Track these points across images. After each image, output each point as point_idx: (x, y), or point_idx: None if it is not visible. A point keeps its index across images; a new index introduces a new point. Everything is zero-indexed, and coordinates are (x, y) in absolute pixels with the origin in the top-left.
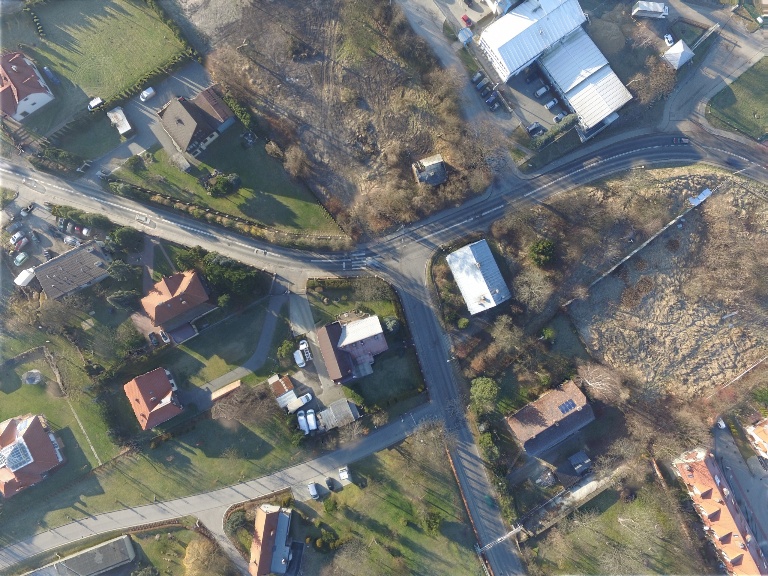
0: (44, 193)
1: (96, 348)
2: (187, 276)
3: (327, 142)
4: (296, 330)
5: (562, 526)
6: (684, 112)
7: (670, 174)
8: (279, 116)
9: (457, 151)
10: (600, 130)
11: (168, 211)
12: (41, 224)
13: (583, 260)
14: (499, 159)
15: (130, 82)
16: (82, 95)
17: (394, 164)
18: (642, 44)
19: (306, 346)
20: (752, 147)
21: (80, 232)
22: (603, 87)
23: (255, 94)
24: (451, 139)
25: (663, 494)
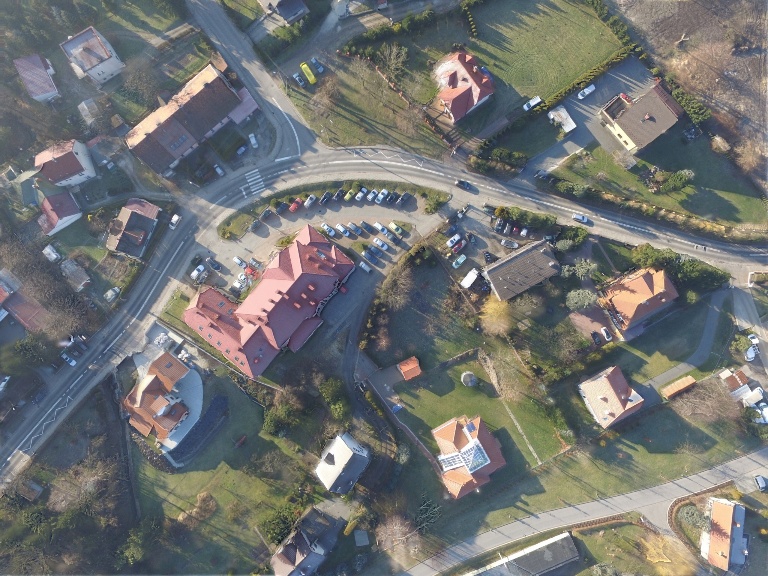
0: (478, 194)
1: (533, 348)
2: (656, 274)
3: (766, 136)
4: (741, 324)
5: None
6: None
7: None
8: (719, 111)
9: None
10: None
11: (605, 209)
12: (475, 226)
13: None
14: None
15: (565, 80)
16: (515, 94)
17: None
18: None
19: (758, 340)
20: None
21: (517, 233)
22: None
23: (694, 89)
24: None
25: None
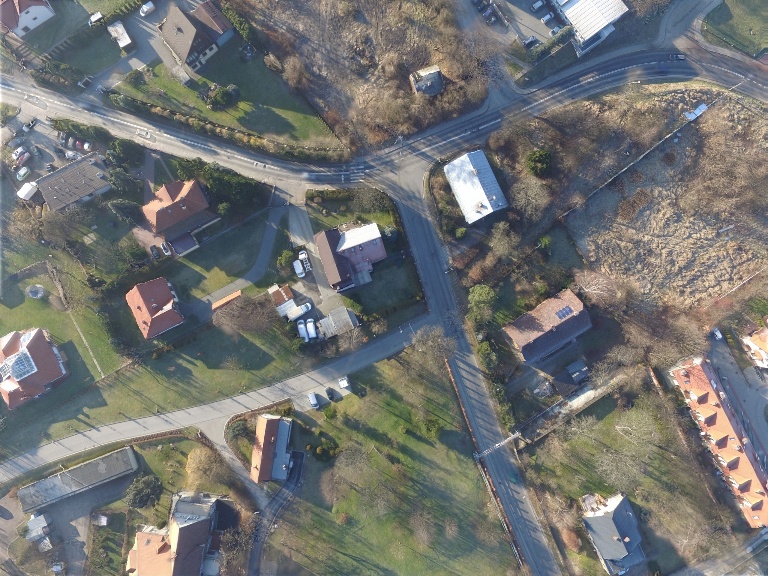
0: (46, 109)
1: (98, 262)
2: (187, 184)
3: (325, 55)
4: (295, 241)
5: (560, 433)
6: (680, 29)
7: (666, 88)
8: (277, 30)
9: (454, 62)
10: (596, 44)
11: (168, 125)
12: (43, 140)
13: (580, 173)
14: (496, 71)
15: None
16: (83, 11)
17: (392, 76)
18: None
19: (305, 256)
20: (748, 64)
21: (81, 147)
22: None
23: (254, 8)
24: (448, 50)
25: (660, 401)
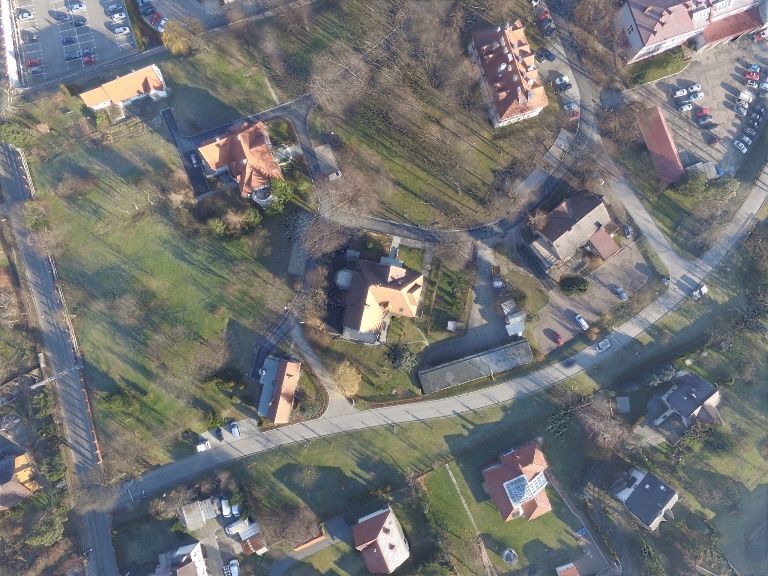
0: None
1: None
2: None
3: None
4: None
5: None
6: None
7: None
8: None
9: None
10: None
11: None
12: None
13: None
14: None
15: None
16: None
17: None
18: None
19: None
20: None
21: None
22: None
23: None
24: None
25: None
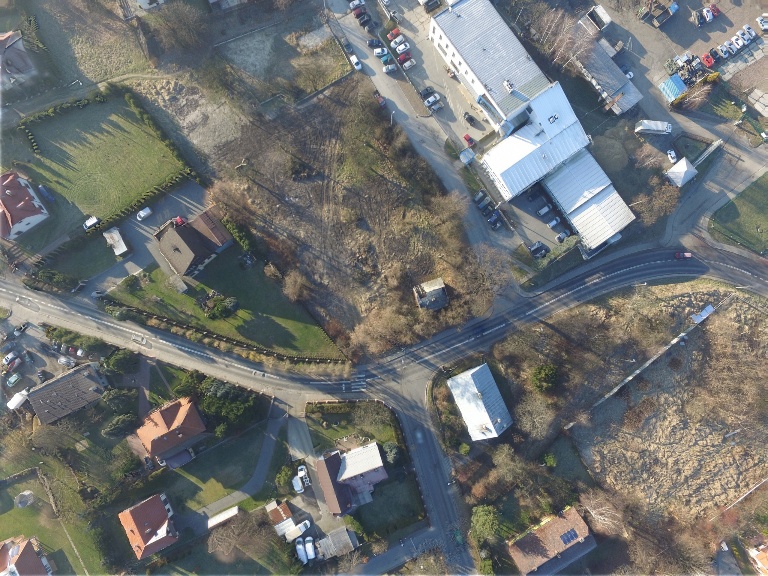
0: (38, 312)
1: (90, 470)
2: (184, 406)
3: (327, 263)
4: (295, 454)
5: None
6: (687, 226)
7: (673, 292)
8: (278, 236)
9: (458, 274)
10: (603, 249)
11: (165, 331)
12: (35, 343)
13: (585, 380)
14: (501, 281)
15: (127, 200)
16: (77, 212)
17: (395, 287)
18: (645, 164)
19: (305, 472)
20: (755, 261)
21: (75, 352)
22: (606, 208)
23: (254, 214)
24: (452, 262)
25: None
